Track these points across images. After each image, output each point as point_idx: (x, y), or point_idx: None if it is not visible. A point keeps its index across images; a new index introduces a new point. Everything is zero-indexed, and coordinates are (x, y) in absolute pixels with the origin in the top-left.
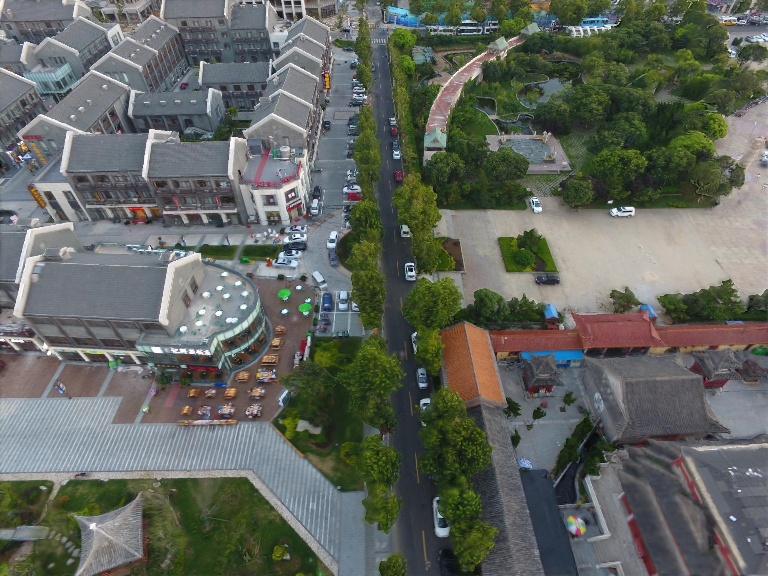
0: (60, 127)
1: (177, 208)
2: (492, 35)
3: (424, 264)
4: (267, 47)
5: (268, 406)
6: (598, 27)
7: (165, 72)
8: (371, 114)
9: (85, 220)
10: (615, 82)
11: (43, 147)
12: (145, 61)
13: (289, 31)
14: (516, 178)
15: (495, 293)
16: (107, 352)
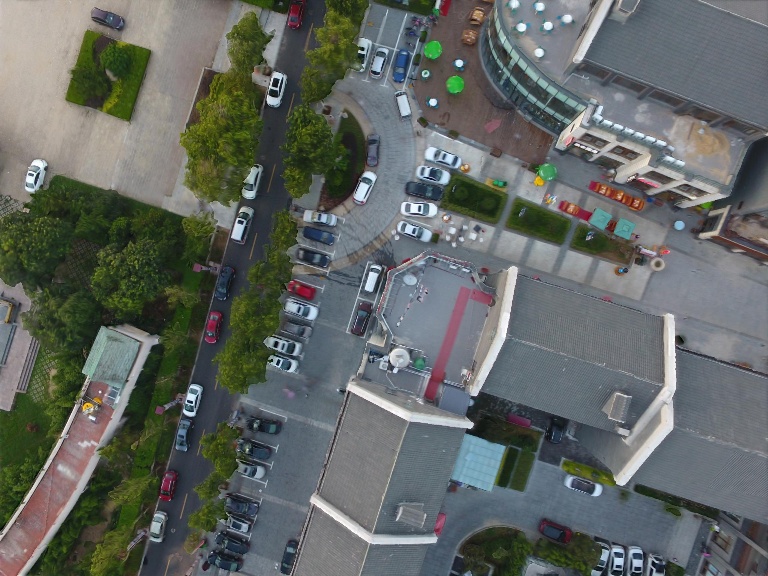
0: None
1: None
2: None
3: None
4: None
5: None
6: None
7: None
8: None
9: None
10: None
11: None
12: None
13: None
14: None
15: None
16: None
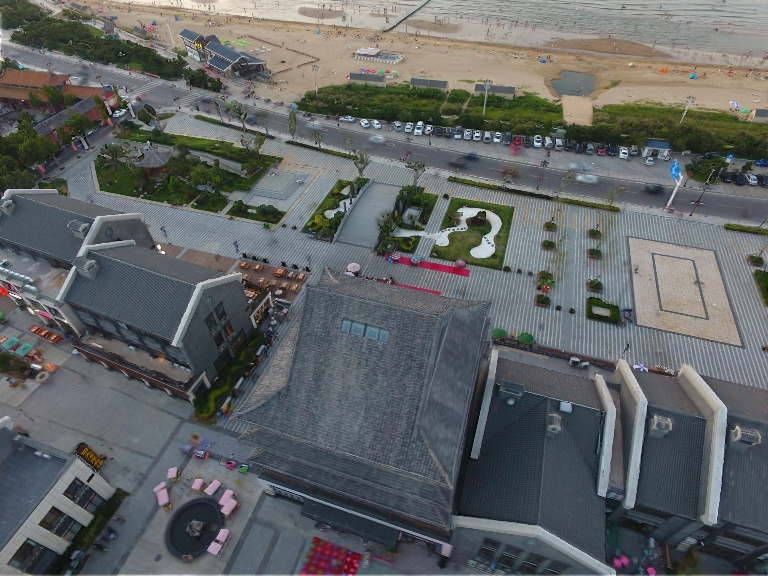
0: None
1: None
2: None
3: None
4: None
5: None
6: None
7: None
8: None
9: None
10: None
11: None
12: None
13: None
14: None
15: None
16: None
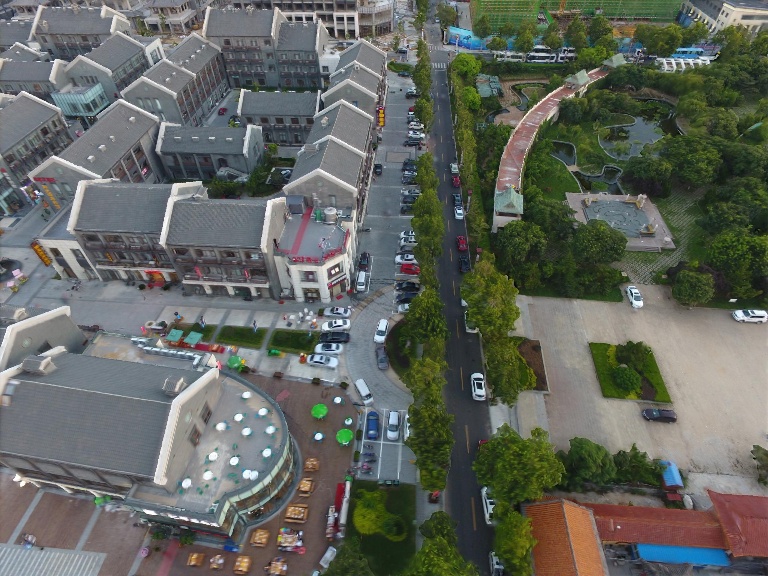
0: (75, 170)
1: (199, 278)
2: (569, 65)
3: (501, 391)
4: (315, 71)
5: None
6: (694, 60)
7: (203, 96)
8: (431, 162)
9: (95, 279)
10: (724, 133)
11: (56, 190)
12: (181, 86)
13: (341, 55)
14: (611, 261)
15: (599, 446)
16: (92, 490)
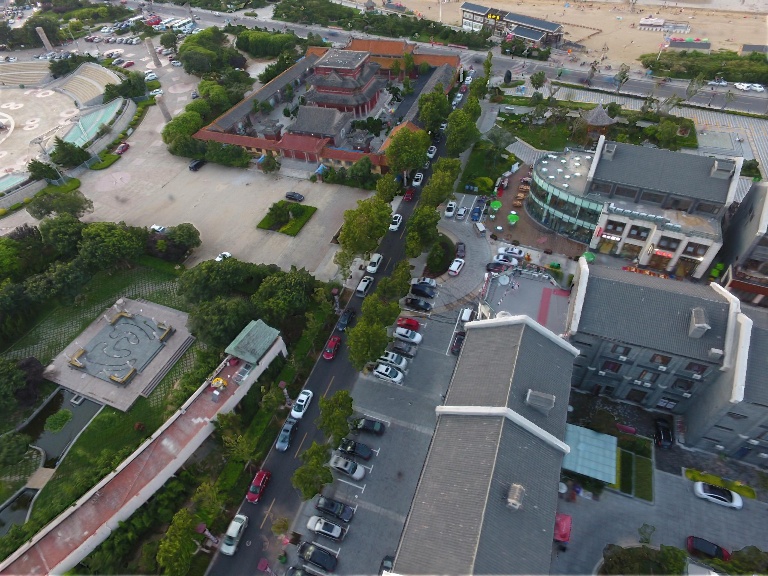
0: None
1: None
2: None
3: None
4: None
5: (526, 170)
6: None
7: None
8: None
9: None
10: None
11: None
12: None
13: None
14: None
15: (354, 166)
16: None
